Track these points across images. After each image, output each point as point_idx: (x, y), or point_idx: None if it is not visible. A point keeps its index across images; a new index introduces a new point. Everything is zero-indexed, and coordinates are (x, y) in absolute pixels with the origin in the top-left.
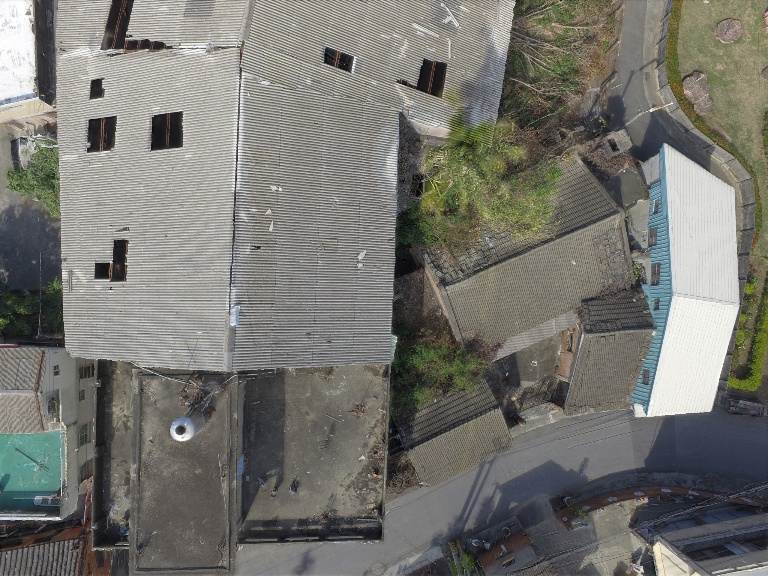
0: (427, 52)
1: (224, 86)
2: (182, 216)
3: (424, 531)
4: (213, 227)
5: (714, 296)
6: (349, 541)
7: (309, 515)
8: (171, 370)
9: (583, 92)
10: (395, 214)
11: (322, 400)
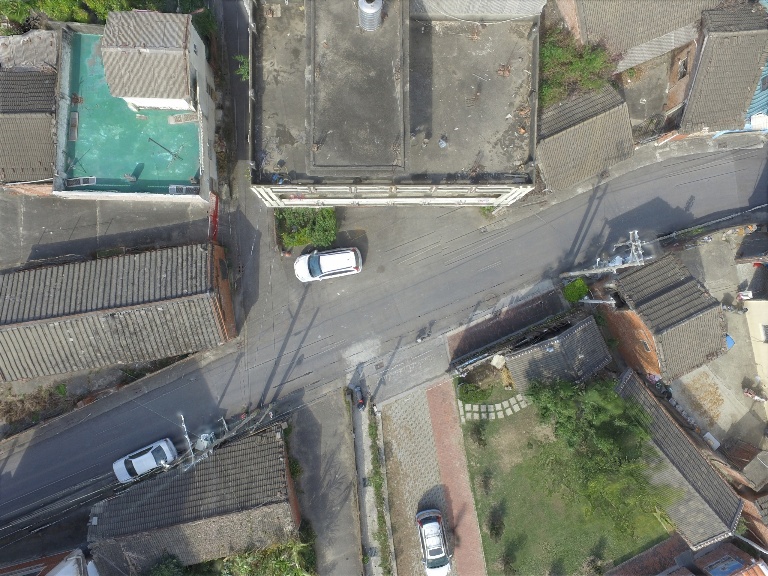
0: None
1: None
2: None
3: (535, 264)
4: None
5: None
6: (502, 185)
7: (458, 170)
8: None
9: None
10: None
11: (469, 60)
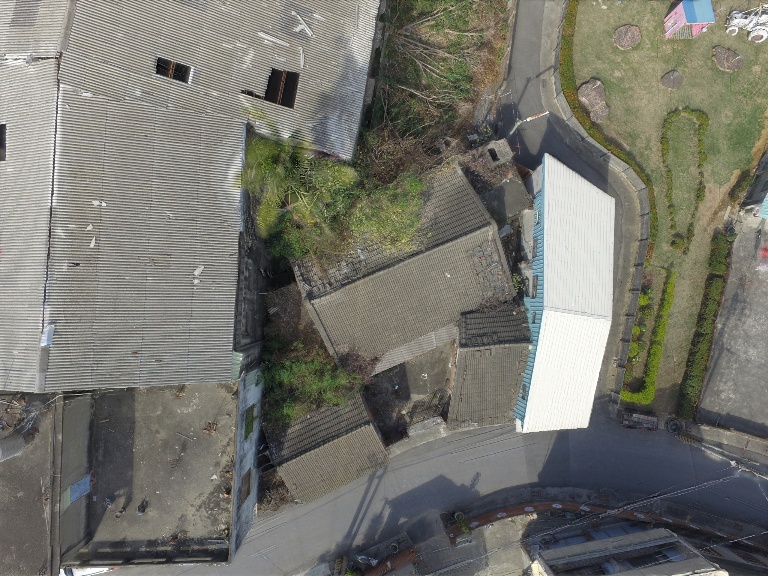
0: (276, 61)
1: (43, 98)
2: (3, 232)
3: (311, 547)
4: (30, 243)
5: (586, 310)
6: None
7: (158, 536)
8: None
9: (475, 100)
10: (238, 228)
11: (173, 418)
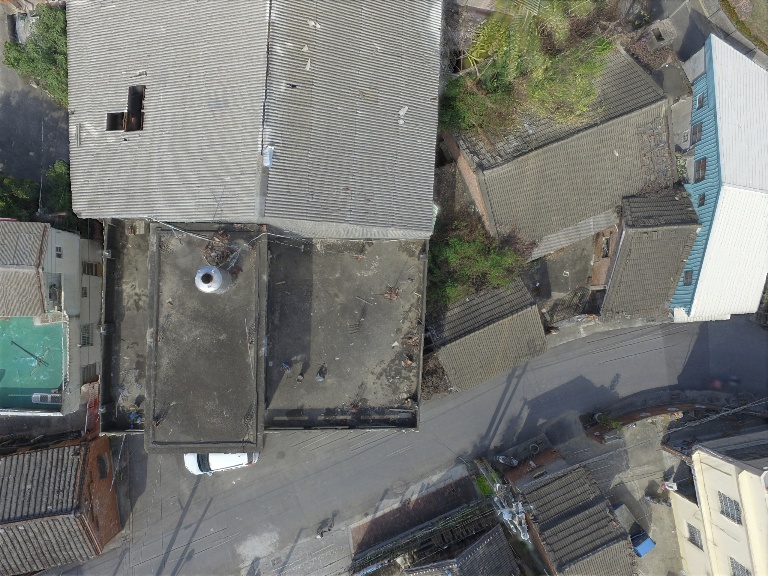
0: None
1: None
2: (208, 53)
3: None
4: (243, 62)
5: (764, 187)
6: None
7: (337, 404)
8: (193, 226)
9: None
10: (438, 72)
11: (353, 281)
